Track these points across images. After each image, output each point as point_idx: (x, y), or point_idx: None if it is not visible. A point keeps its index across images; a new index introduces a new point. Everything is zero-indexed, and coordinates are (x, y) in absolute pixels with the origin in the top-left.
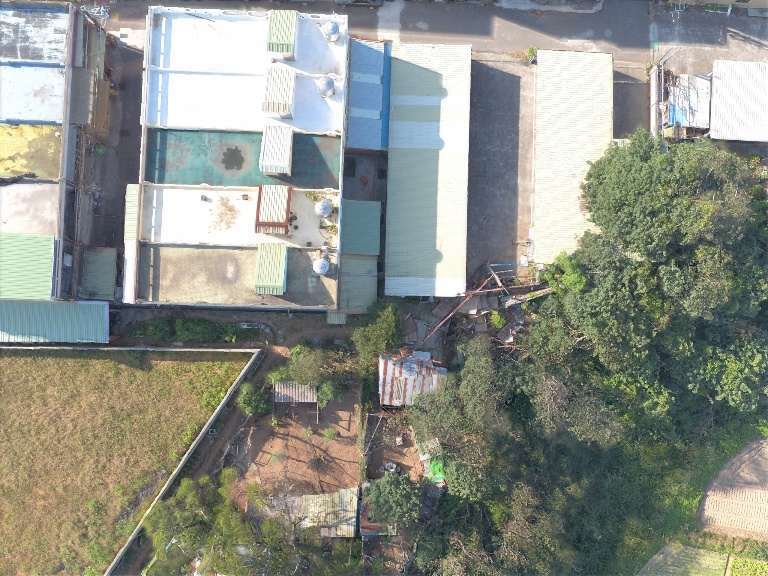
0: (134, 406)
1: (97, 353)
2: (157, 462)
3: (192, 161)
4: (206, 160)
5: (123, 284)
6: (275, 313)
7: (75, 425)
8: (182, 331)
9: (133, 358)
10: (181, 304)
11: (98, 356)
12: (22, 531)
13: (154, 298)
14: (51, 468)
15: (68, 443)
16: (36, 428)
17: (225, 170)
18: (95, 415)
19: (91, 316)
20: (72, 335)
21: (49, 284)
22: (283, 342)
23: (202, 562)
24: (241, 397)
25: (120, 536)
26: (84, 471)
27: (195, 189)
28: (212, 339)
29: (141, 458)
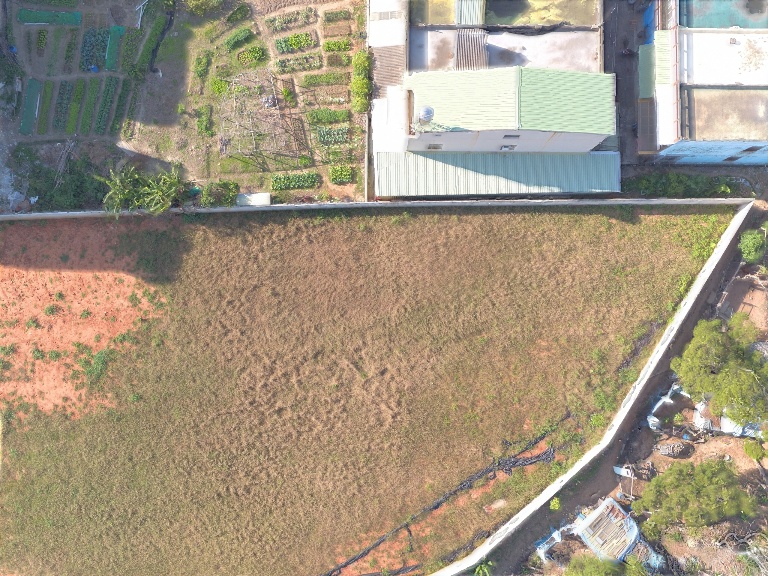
0: (628, 258)
1: (589, 208)
2: (654, 312)
3: (718, 6)
4: (731, 5)
5: (657, 126)
6: (753, 167)
7: (573, 278)
8: (678, 182)
9: (626, 212)
10: (698, 149)
11: (590, 211)
12: (529, 381)
13: (691, 138)
14: (554, 319)
15: (569, 295)
16: (538, 281)
17: (750, 14)
18: (591, 268)
19: (604, 166)
20: (586, 185)
21: (613, 120)
22: (761, 195)
23: (708, 405)
24: (745, 243)
25: (621, 384)
26: (585, 322)
27: (723, 33)
28: (700, 192)
29: (638, 308)
